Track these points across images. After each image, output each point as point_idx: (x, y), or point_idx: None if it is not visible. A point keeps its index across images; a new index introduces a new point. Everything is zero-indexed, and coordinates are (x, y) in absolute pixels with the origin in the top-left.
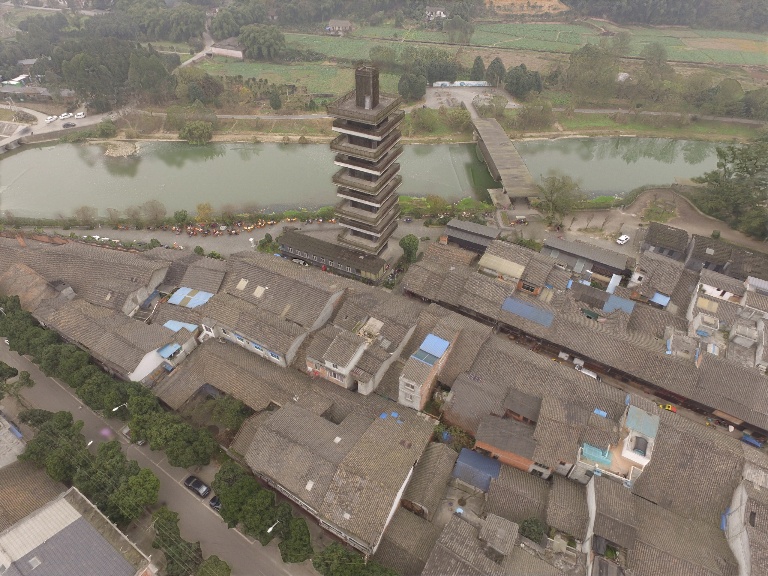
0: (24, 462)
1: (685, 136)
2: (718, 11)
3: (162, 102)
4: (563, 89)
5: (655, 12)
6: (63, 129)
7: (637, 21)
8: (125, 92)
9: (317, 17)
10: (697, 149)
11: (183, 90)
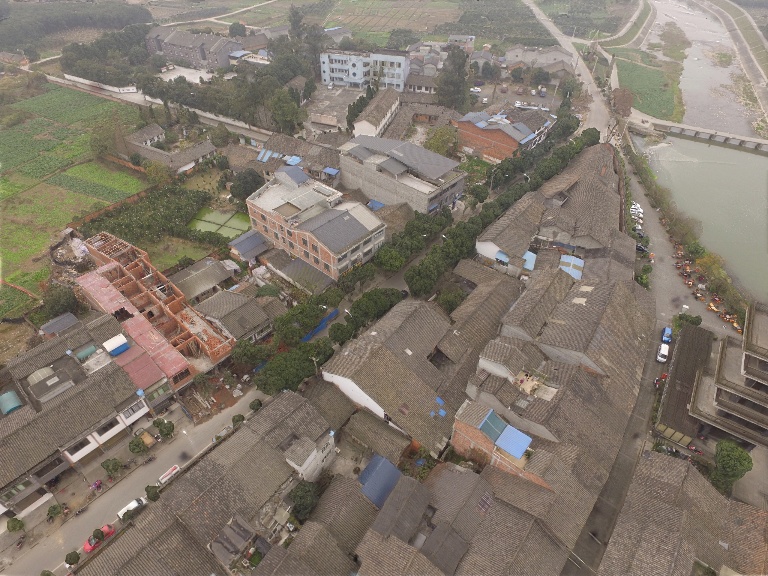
0: None
1: None
2: None
3: None
4: None
5: None
6: None
7: None
8: None
9: None
10: None
11: None
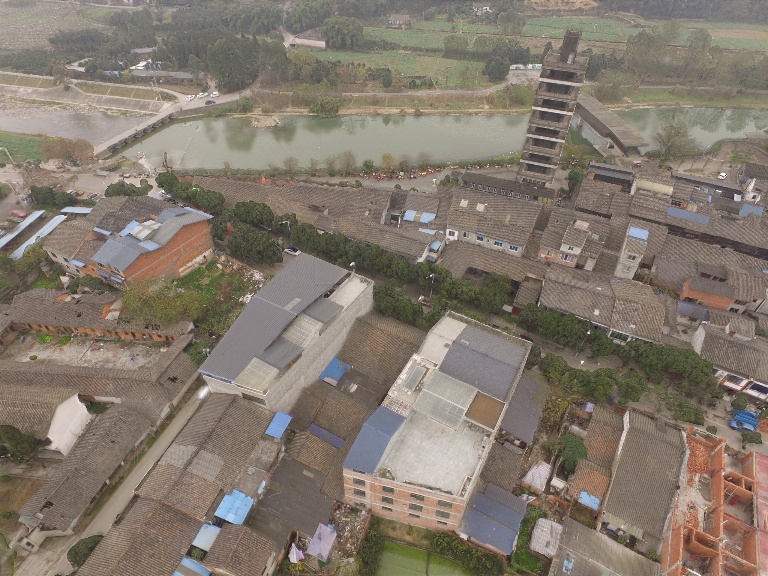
0: (373, 313)
1: (734, 106)
2: (730, 6)
3: (281, 83)
4: (620, 70)
5: (676, 7)
6: (206, 105)
7: (659, 15)
8: (251, 74)
9: (373, 13)
10: (739, 119)
11: (308, 71)
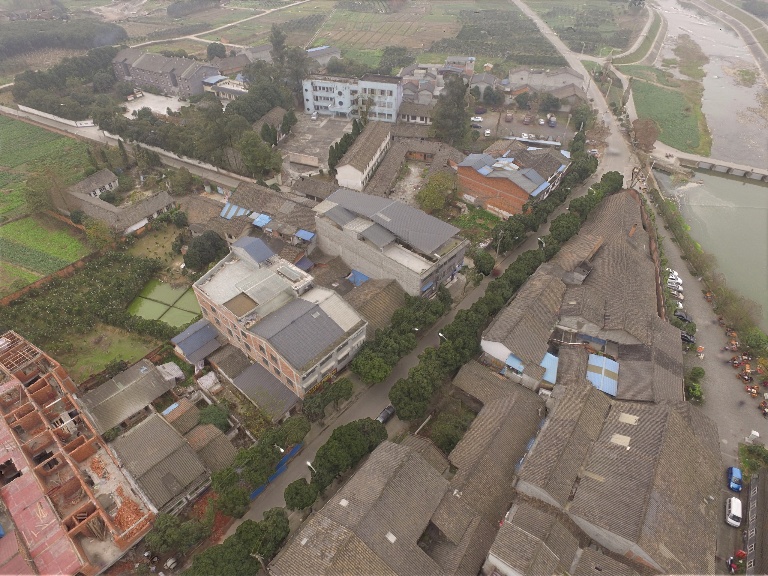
0: None
1: None
2: None
3: None
4: None
5: None
6: None
7: None
8: None
9: None
10: None
11: None
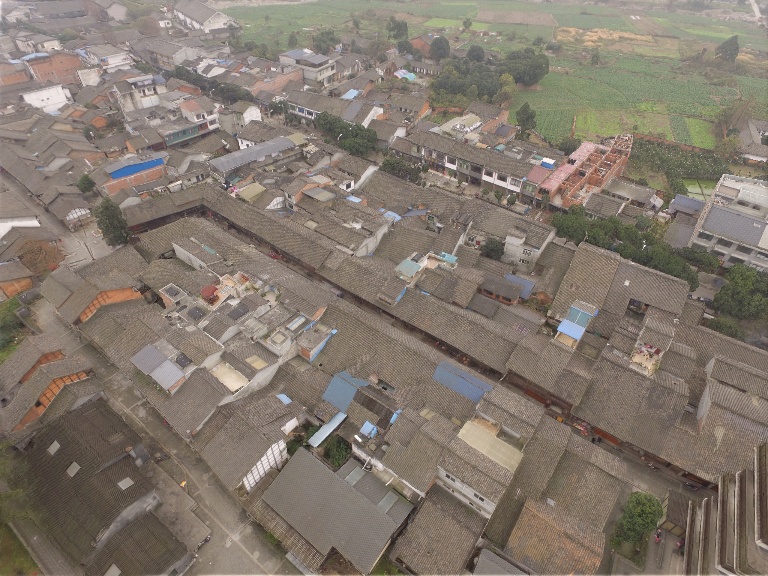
0: None
1: None
2: None
3: None
4: None
5: None
6: None
7: None
8: None
9: None
10: None
11: None
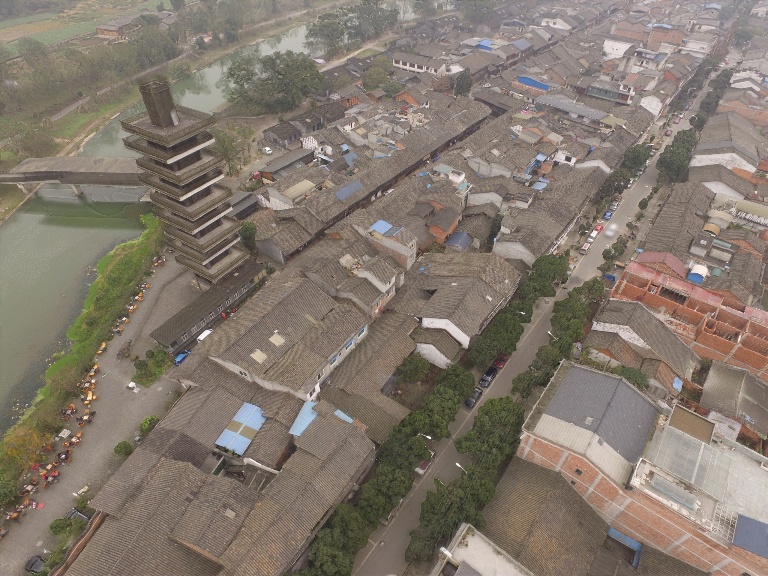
0: None
1: None
2: None
3: None
4: None
5: None
6: None
7: None
8: None
9: None
10: None
11: None
